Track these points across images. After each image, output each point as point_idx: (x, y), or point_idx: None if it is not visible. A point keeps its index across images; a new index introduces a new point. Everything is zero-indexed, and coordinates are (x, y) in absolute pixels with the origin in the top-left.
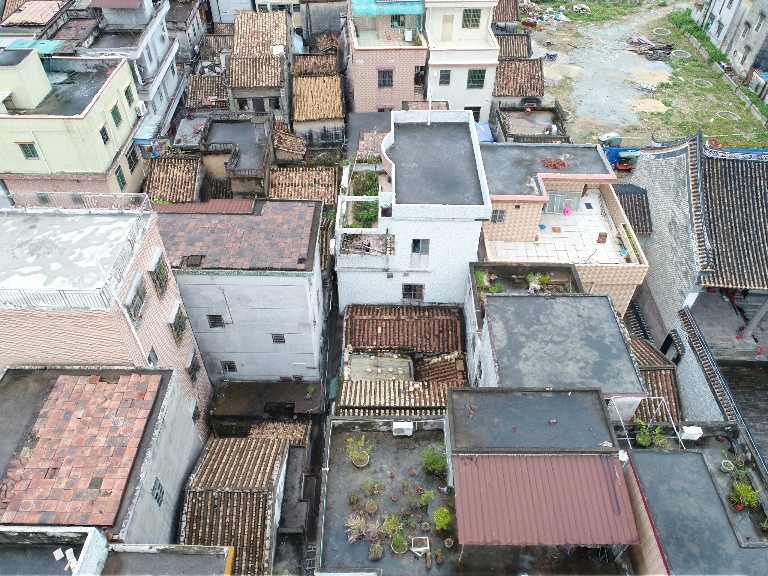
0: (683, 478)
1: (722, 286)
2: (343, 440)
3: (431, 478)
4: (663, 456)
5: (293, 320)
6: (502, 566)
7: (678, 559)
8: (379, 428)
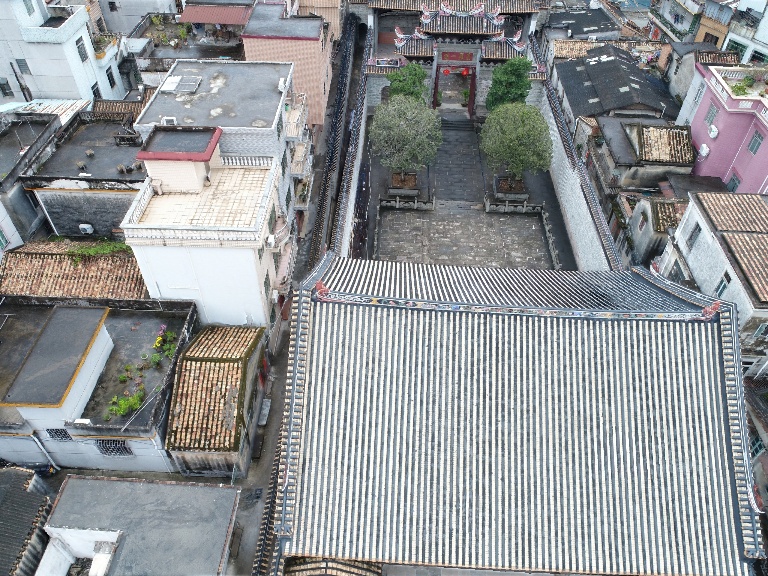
0: (272, 8)
1: (379, 7)
2: (155, 25)
3: (188, 33)
4: (269, 5)
5: (150, 5)
6: (205, 48)
7: (253, 19)
8: (172, 21)
